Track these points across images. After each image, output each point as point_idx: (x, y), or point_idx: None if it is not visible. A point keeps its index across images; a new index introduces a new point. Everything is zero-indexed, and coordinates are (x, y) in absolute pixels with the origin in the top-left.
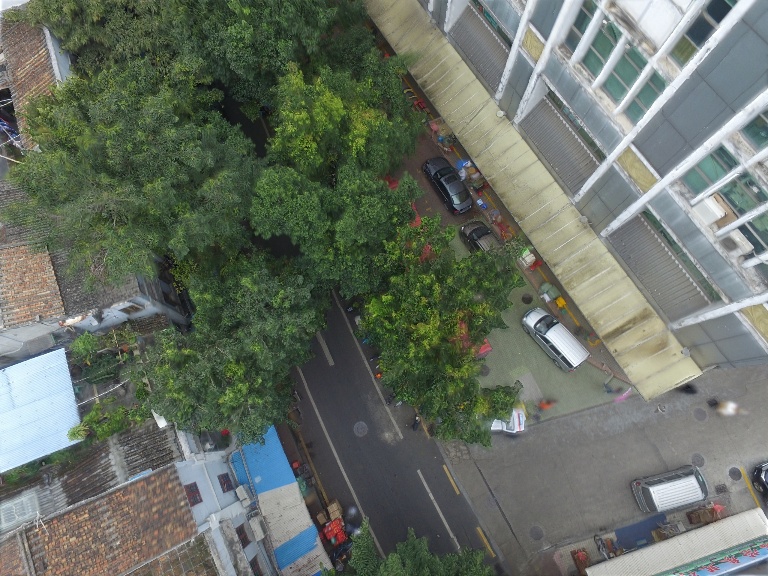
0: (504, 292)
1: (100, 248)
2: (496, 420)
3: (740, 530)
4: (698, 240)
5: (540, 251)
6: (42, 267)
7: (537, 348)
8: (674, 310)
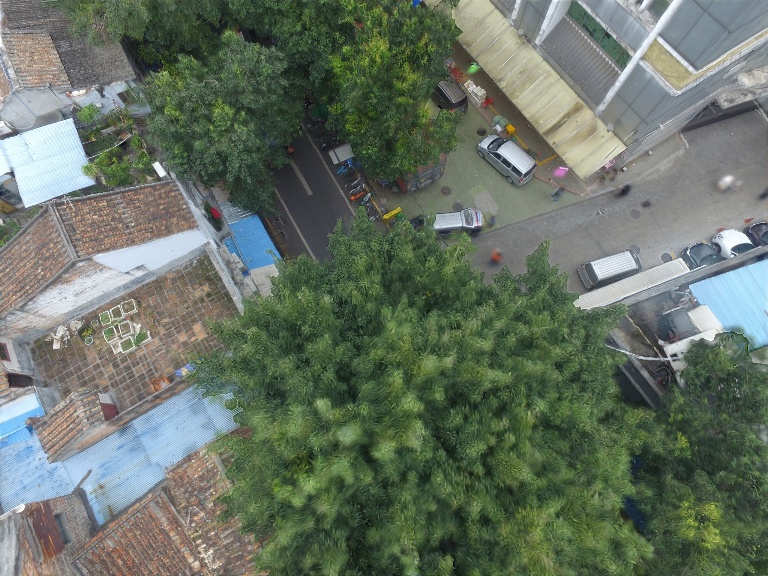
0: (443, 34)
1: (100, 9)
2: (457, 218)
3: (664, 274)
4: (605, 2)
5: (486, 70)
6: (48, 50)
7: (492, 170)
8: (599, 94)
